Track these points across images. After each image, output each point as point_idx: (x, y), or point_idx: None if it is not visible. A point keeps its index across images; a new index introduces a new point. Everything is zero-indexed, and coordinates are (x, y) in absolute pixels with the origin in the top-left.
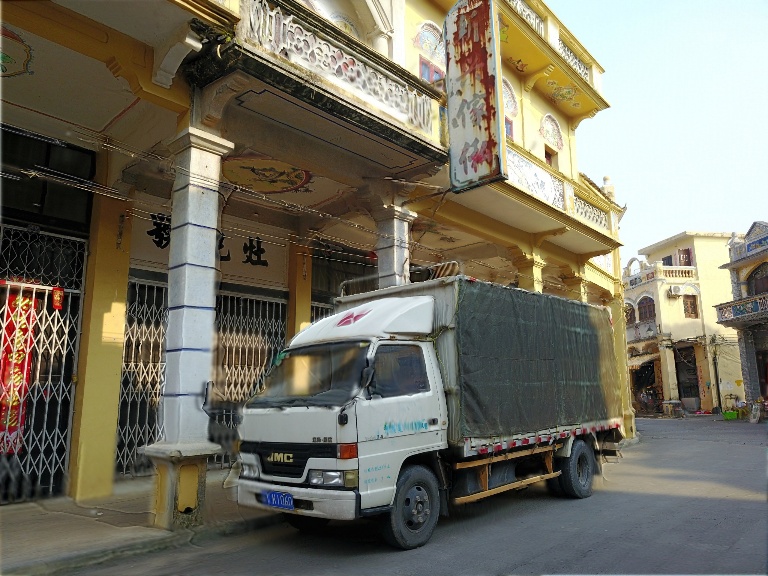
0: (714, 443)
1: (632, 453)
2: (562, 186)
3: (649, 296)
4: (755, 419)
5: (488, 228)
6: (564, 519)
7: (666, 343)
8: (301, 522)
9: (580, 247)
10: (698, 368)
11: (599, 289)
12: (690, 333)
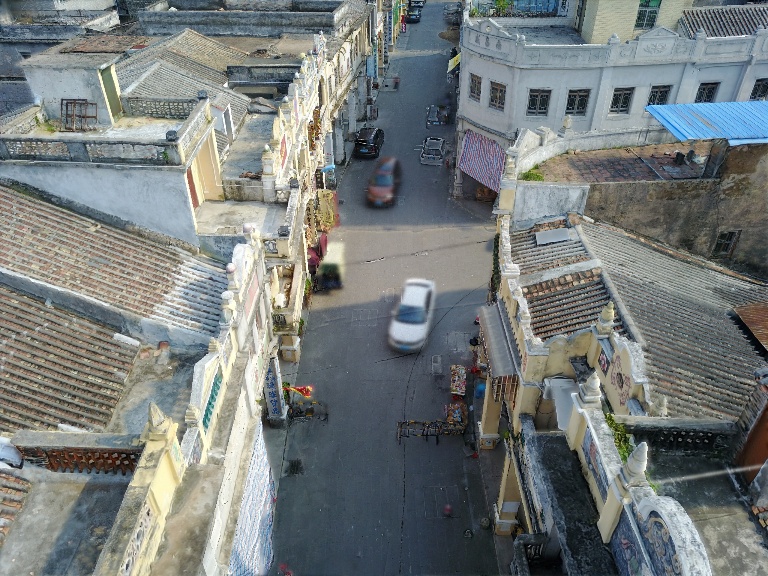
0: None
1: None
2: None
3: None
4: None
5: None
6: (428, 4)
7: None
8: (418, 6)
9: None
10: None
11: None
12: None
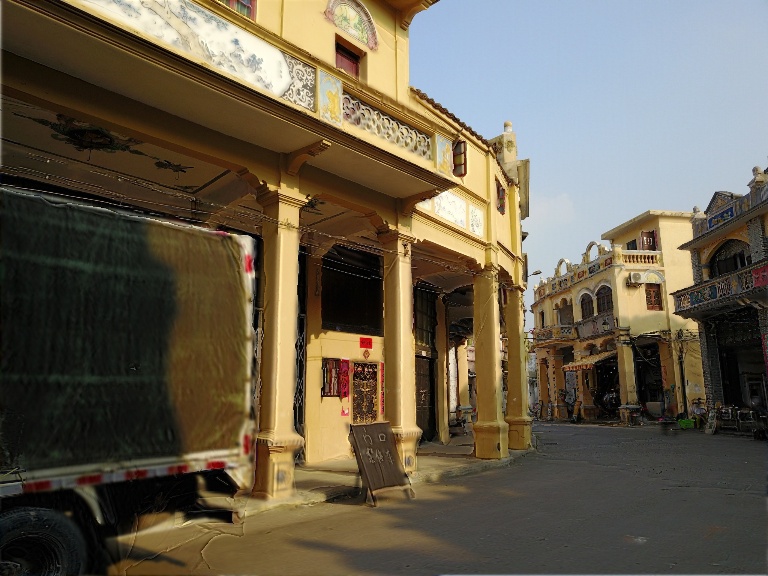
0: (597, 469)
1: (452, 487)
2: (313, 75)
3: (607, 285)
4: (711, 429)
5: (162, 130)
6: None
7: (624, 339)
8: None
9: (388, 185)
10: (662, 368)
11: (455, 255)
12: (652, 327)
